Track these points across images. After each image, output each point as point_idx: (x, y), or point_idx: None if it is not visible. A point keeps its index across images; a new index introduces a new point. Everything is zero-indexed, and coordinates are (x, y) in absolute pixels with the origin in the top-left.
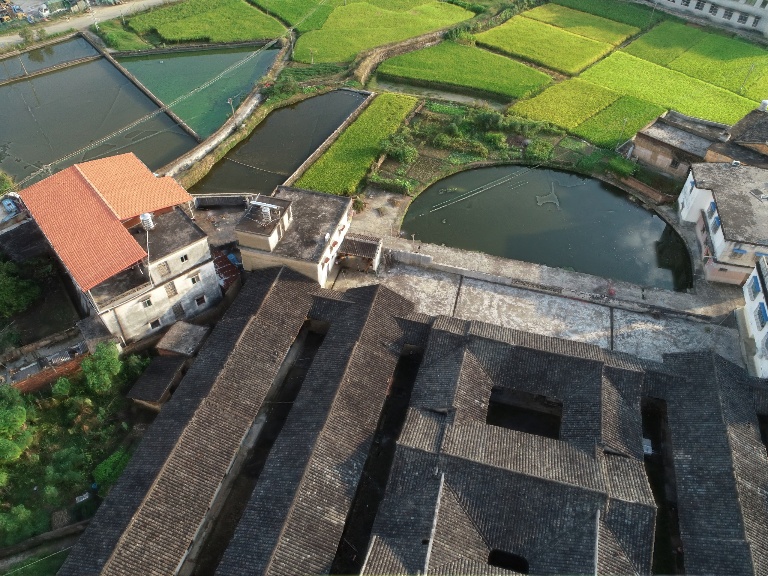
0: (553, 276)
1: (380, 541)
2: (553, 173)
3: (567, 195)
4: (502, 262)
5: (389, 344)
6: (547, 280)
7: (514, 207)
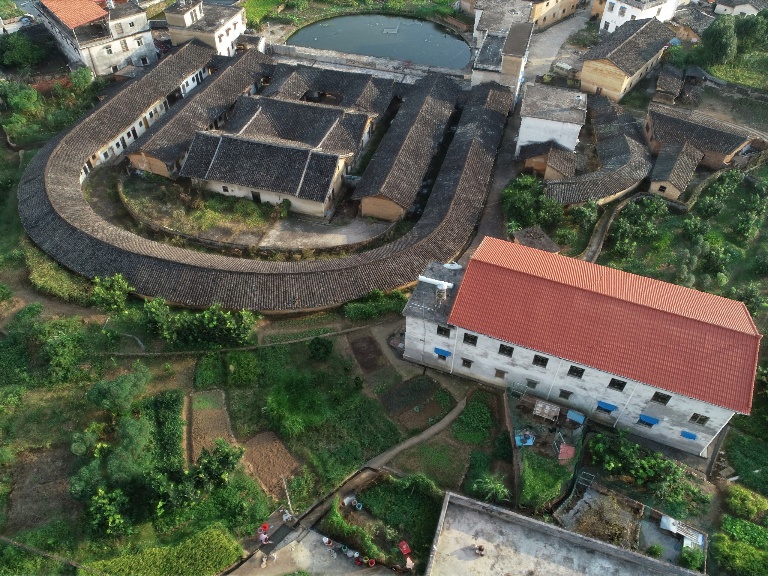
0: (375, 61)
1: None
2: (402, 19)
3: (405, 28)
4: (344, 55)
5: (252, 73)
6: None
7: (366, 33)
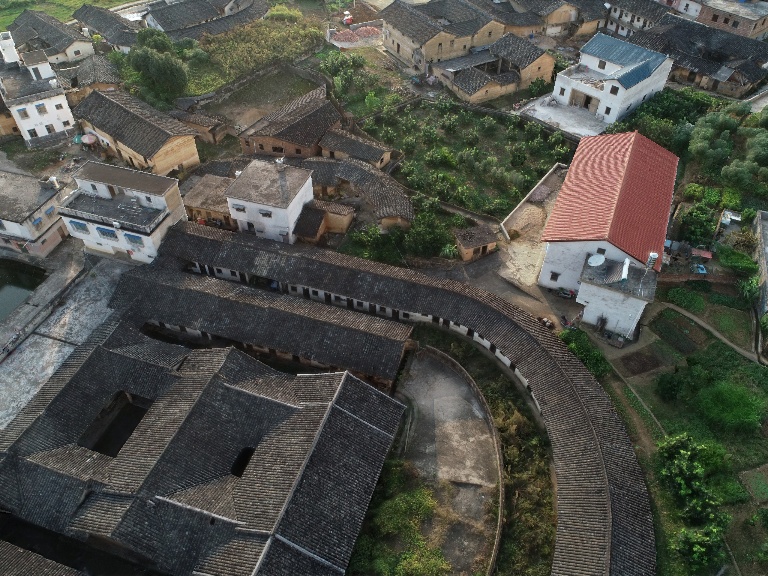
0: None
1: (199, 567)
2: None
3: None
4: None
5: None
6: None
7: None
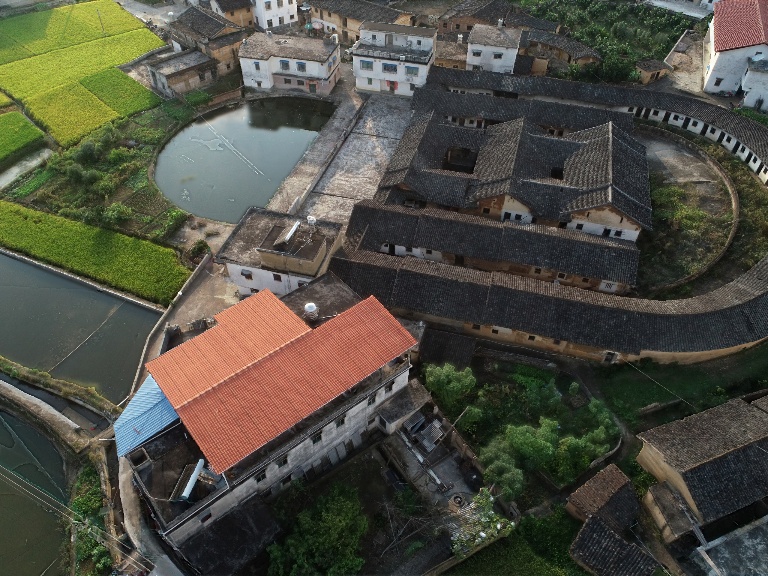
0: (318, 150)
1: None
2: (175, 139)
3: None
4: (299, 170)
5: None
6: (322, 153)
7: (222, 161)
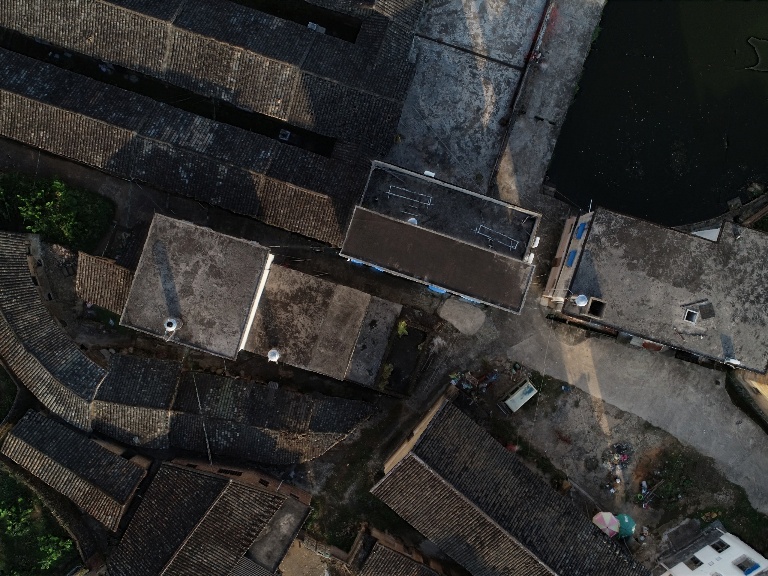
0: (583, 7)
1: None
2: None
3: None
4: None
5: None
6: None
7: None
